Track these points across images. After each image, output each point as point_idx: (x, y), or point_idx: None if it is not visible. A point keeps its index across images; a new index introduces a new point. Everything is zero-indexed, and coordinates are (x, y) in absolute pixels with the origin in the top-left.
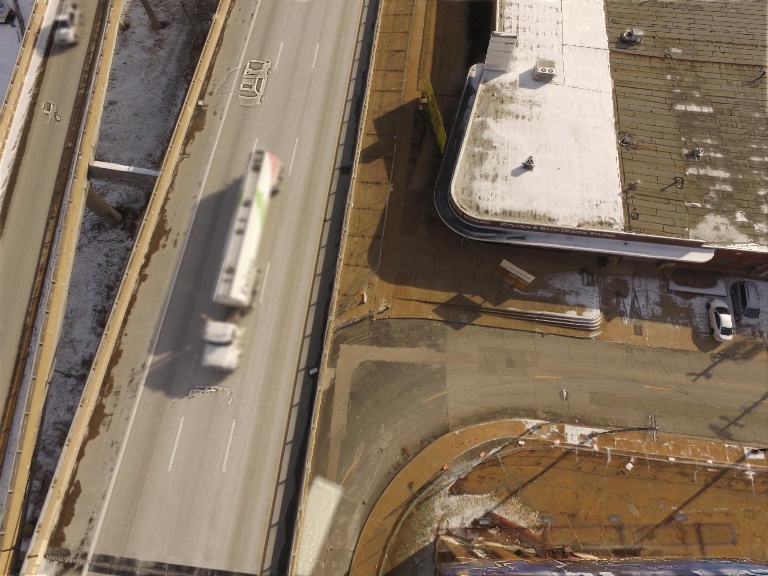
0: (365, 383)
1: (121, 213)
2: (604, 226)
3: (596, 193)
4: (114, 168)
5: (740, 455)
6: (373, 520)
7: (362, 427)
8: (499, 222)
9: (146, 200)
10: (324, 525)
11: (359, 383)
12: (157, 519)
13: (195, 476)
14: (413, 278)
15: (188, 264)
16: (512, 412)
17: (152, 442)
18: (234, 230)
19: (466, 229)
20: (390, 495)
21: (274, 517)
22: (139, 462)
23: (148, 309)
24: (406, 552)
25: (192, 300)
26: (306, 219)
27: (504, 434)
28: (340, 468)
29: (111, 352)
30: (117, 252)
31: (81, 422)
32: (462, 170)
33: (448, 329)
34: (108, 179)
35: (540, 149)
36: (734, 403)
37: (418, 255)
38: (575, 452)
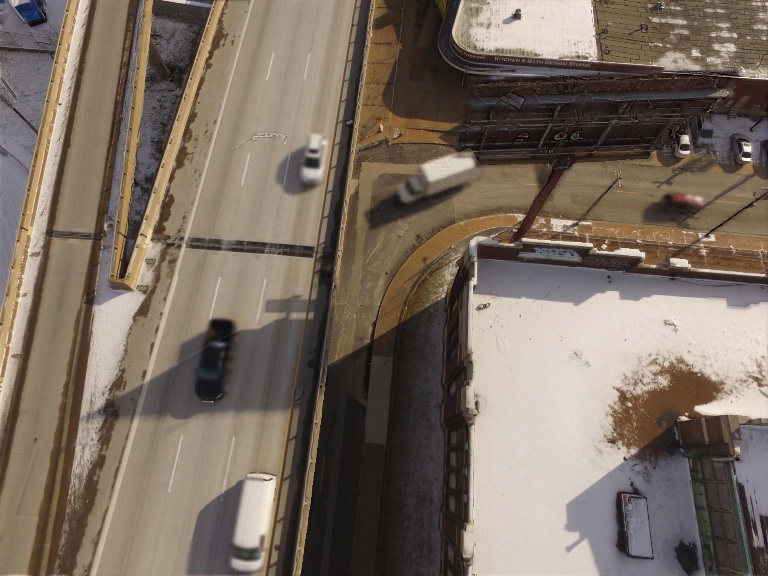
0: (384, 189)
1: (169, 69)
2: (581, 59)
3: (574, 35)
4: (174, 1)
5: (695, 239)
6: (395, 284)
7: (383, 220)
8: (493, 56)
9: (190, 59)
10: (354, 289)
11: (379, 189)
12: (235, 215)
13: (262, 189)
14: (421, 113)
15: (244, 56)
16: (507, 210)
17: (227, 169)
18: (279, 33)
19: (466, 65)
20: (408, 267)
21: (325, 212)
22: (218, 181)
23: (215, 86)
24: (422, 305)
25: (250, 79)
26: (337, 24)
27: (500, 224)
28: (366, 249)
29: (188, 113)
30: (168, 98)
31: (170, 155)
32: (461, 20)
33: (452, 151)
34: (167, 16)
35: (527, 4)
36: (691, 202)
37: (425, 96)
38: (559, 237)
